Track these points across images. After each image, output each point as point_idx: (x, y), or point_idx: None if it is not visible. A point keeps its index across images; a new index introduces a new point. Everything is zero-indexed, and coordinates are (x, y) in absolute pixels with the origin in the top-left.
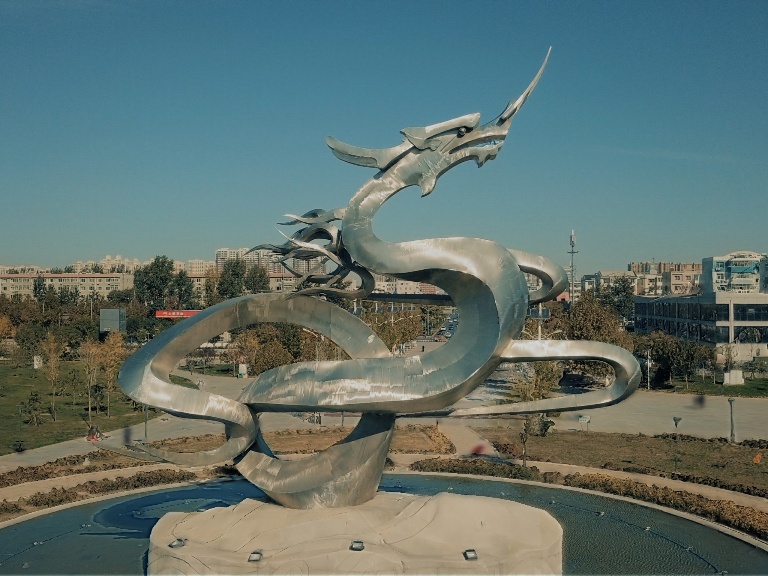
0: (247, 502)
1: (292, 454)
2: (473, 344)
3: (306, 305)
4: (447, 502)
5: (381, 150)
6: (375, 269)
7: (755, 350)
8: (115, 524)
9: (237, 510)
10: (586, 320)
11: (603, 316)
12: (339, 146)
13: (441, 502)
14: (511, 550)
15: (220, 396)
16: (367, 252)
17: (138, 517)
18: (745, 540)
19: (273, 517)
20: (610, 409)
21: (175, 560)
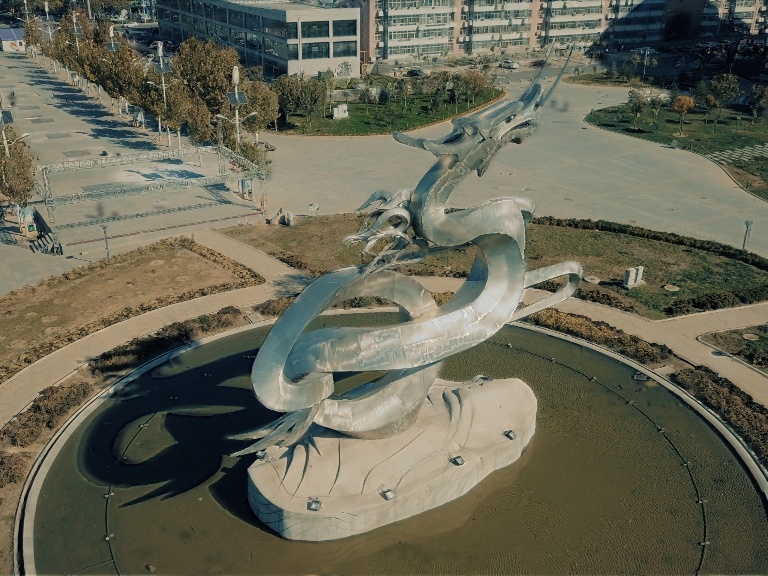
0: (322, 442)
1: (125, 320)
2: (506, 287)
3: (377, 279)
4: (477, 399)
5: (461, 146)
6: (445, 245)
7: (319, 65)
8: (128, 481)
9: (325, 454)
10: (219, 70)
11: (233, 64)
12: (433, 147)
13: (473, 400)
14: (523, 420)
15: (326, 377)
16: (440, 232)
17: (132, 463)
18: (572, 341)
19: (366, 453)
20: (287, 173)
21: (326, 520)
